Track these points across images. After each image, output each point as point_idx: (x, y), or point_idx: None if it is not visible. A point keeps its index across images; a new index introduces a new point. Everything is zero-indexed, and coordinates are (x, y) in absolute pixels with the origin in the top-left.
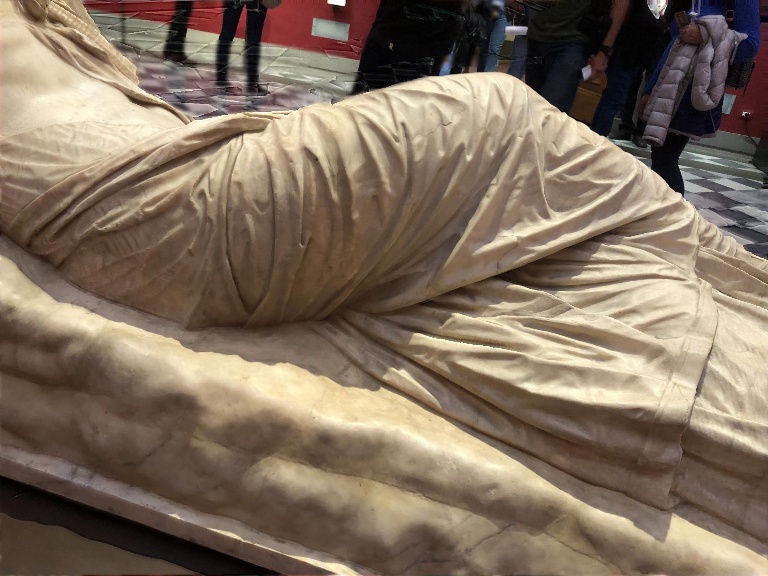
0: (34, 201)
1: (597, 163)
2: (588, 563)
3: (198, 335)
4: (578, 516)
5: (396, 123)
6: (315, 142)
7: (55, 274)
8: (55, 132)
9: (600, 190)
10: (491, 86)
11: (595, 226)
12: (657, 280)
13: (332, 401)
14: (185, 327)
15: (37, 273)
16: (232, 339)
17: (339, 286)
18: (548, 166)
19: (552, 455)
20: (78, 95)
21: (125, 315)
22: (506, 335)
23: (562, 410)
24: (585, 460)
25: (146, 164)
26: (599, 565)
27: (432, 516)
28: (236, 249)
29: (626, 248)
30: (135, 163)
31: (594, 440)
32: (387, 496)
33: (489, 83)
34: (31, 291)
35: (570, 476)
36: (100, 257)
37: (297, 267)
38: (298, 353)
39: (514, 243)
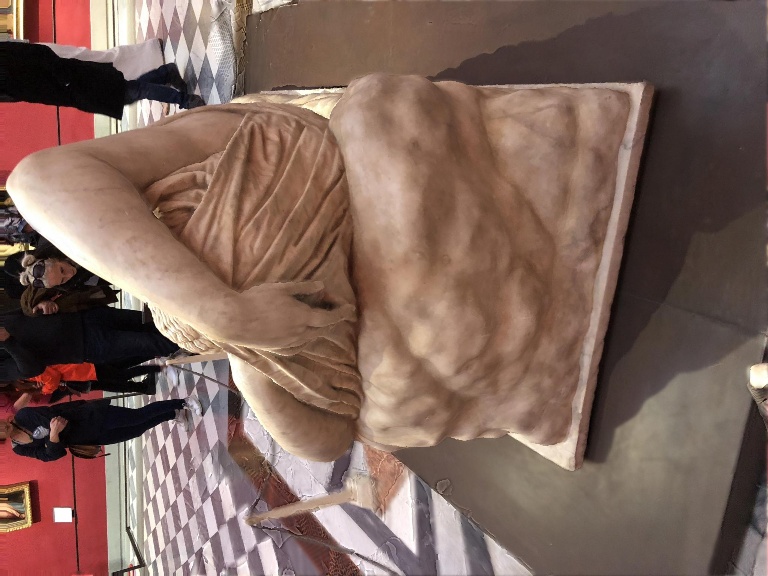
0: None
1: None
2: None
3: None
4: None
5: None
6: None
7: None
8: None
9: None
10: None
11: None
12: None
13: None
14: None
15: None
16: None
17: None
18: None
19: None
20: None
21: None
22: None
23: None
24: None
25: None
26: (269, 98)
27: None
28: None
29: None
30: None
31: None
32: None
33: None
34: None
35: None
36: None
37: None
38: None
39: None
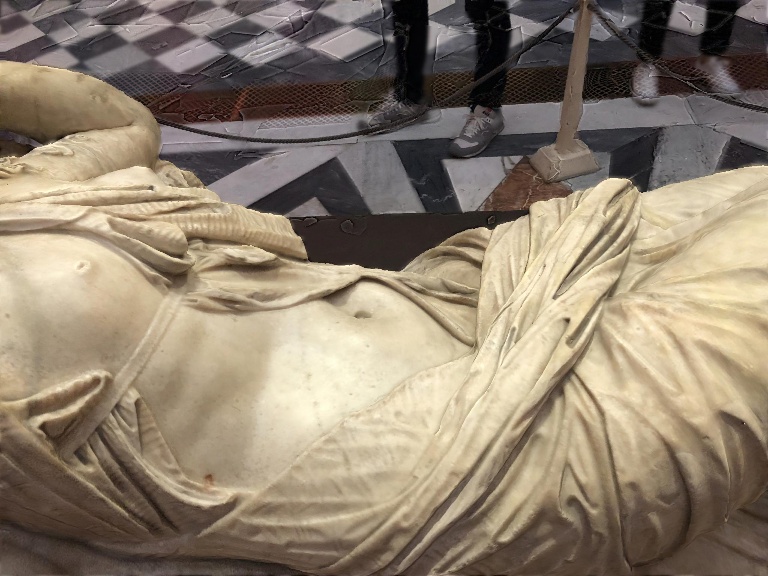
0: (338, 565)
1: None
2: None
3: None
4: None
5: None
6: (731, 396)
7: None
8: (319, 464)
9: None
10: None
11: None
12: None
13: None
14: None
15: None
16: None
17: None
18: None
19: None
20: (290, 358)
21: None
22: None
23: None
24: None
25: (481, 487)
26: None
27: None
28: (634, 546)
29: None
30: (461, 486)
31: None
32: None
33: None
34: None
35: None
36: None
37: None
38: None
39: None
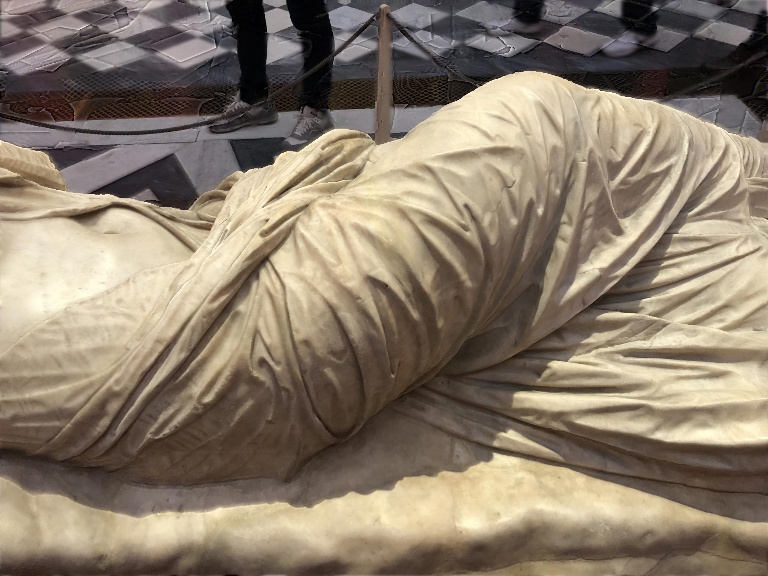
0: (61, 434)
1: (654, 149)
2: (745, 566)
3: (300, 484)
4: (730, 533)
5: (459, 207)
6: (376, 265)
7: (113, 482)
8: (40, 342)
9: (661, 177)
10: (536, 107)
11: (666, 222)
12: (738, 262)
13: (464, 500)
14: (283, 481)
15: (95, 495)
16: (334, 471)
17: (422, 373)
18: (610, 175)
19: (687, 479)
20: (25, 260)
21: (215, 497)
22: (615, 378)
23: (698, 448)
24: (721, 477)
25: (182, 352)
26: (755, 565)
27: (596, 573)
28: (322, 403)
29: (694, 228)
30: (166, 353)
31: (735, 468)
32: (549, 570)
33: (532, 103)
34: (105, 523)
35: (706, 491)
36: (165, 458)
37: (389, 391)
38: (405, 457)
39: (598, 277)
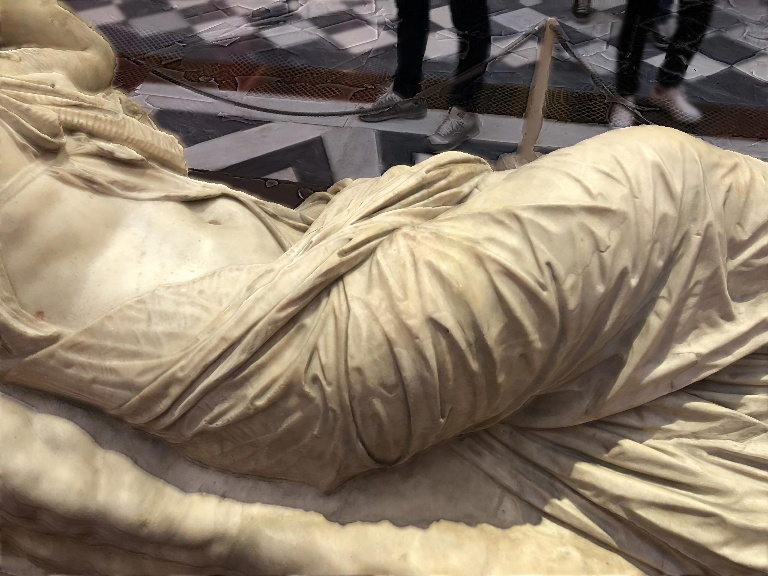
0: (130, 403)
1: None
2: None
3: (338, 499)
4: None
5: (540, 264)
6: (441, 308)
7: (171, 453)
8: (127, 317)
9: None
10: (653, 168)
11: None
12: None
13: (498, 559)
14: (323, 492)
15: (154, 461)
16: (374, 494)
17: (481, 419)
18: (731, 254)
19: None
20: (132, 238)
21: (257, 490)
22: (691, 476)
23: None
24: None
25: (243, 353)
26: None
27: None
28: (367, 430)
29: None
30: (230, 351)
31: None
32: None
33: (650, 163)
34: (156, 490)
35: None
36: (217, 445)
37: None
38: (448, 498)
39: (693, 362)
